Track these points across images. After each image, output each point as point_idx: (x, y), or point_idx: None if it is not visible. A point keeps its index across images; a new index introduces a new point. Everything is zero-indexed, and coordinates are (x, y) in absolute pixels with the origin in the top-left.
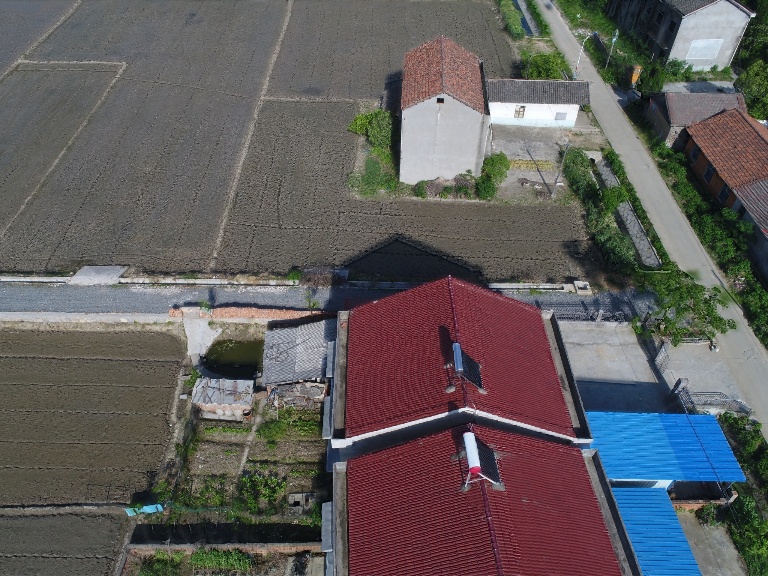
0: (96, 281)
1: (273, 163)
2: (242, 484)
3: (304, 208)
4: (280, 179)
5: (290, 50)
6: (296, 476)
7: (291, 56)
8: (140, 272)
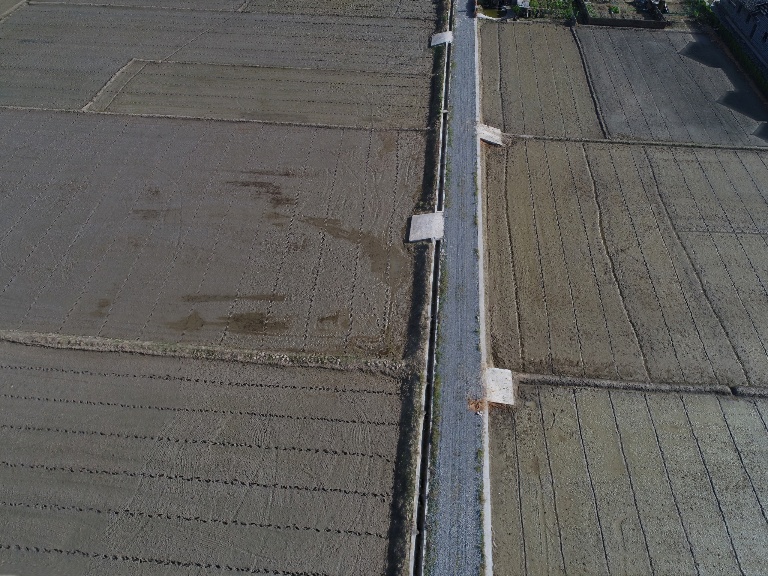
0: (450, 35)
1: (331, 8)
2: (558, 8)
3: (382, 1)
4: (350, 6)
5: (155, 3)
6: (553, 0)
7: (166, 4)
8: (440, 29)
